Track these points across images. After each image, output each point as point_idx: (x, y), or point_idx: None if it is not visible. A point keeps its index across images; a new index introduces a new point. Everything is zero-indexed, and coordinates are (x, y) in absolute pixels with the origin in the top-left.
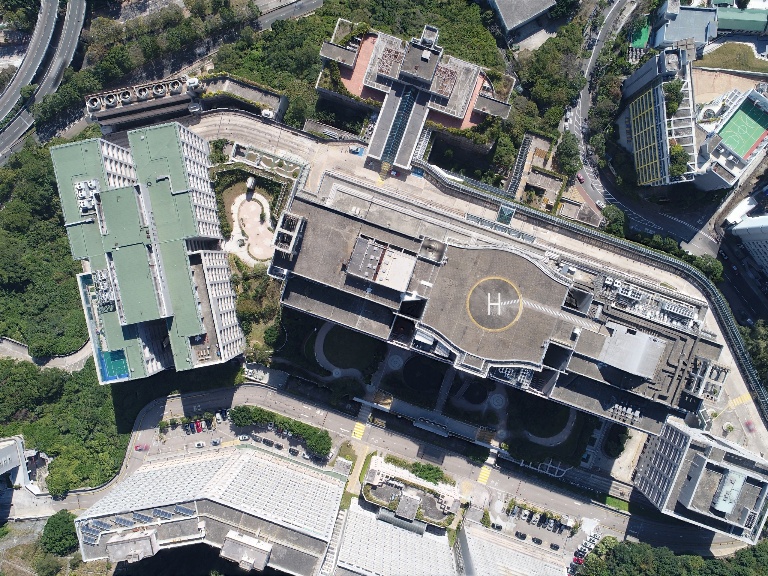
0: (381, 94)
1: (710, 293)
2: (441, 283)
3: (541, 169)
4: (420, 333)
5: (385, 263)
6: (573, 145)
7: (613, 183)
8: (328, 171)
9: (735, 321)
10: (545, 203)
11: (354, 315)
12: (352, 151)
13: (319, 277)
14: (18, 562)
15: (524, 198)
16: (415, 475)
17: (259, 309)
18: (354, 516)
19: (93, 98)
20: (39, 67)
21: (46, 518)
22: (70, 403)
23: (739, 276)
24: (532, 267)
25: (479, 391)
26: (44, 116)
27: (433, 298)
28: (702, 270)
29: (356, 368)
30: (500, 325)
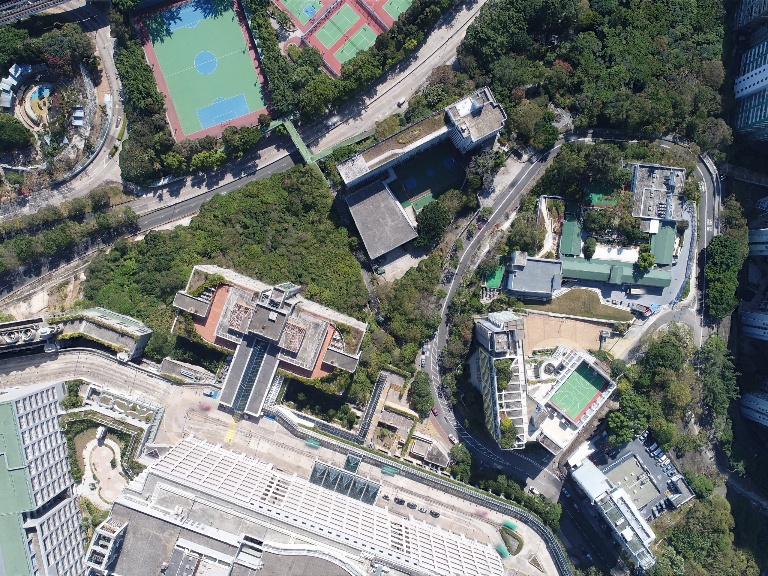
0: None
1: (547, 539)
2: None
3: (393, 409)
4: None
5: (200, 572)
6: (424, 387)
7: None
8: (153, 468)
9: (571, 565)
10: (398, 439)
11: None
12: (206, 394)
13: None
14: None
15: (378, 433)
16: None
17: None
18: None
19: None
20: None
21: None
22: None
23: (580, 513)
24: (344, 573)
25: None
26: None
27: None
28: (541, 514)
29: None
30: None
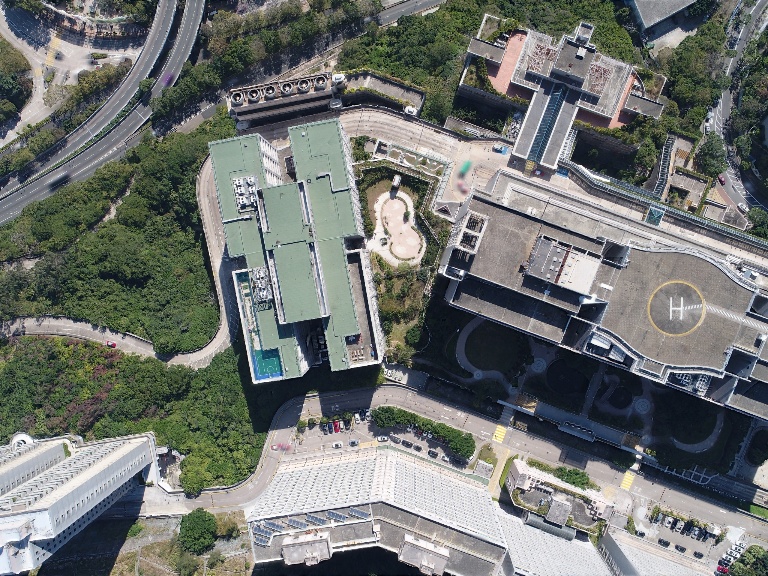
0: (527, 92)
1: None
2: (622, 286)
3: (686, 170)
4: (597, 337)
5: (568, 265)
6: (719, 146)
7: (756, 185)
8: (503, 170)
9: None
10: (687, 205)
11: (526, 317)
12: (495, 150)
13: (496, 278)
14: (155, 560)
15: None
16: (561, 480)
17: (402, 309)
18: (503, 520)
19: (236, 93)
20: (157, 61)
21: (179, 516)
22: (196, 400)
23: None
24: (717, 271)
25: (624, 395)
26: (164, 110)
27: (613, 301)
28: None
29: (498, 370)
30: (681, 330)
